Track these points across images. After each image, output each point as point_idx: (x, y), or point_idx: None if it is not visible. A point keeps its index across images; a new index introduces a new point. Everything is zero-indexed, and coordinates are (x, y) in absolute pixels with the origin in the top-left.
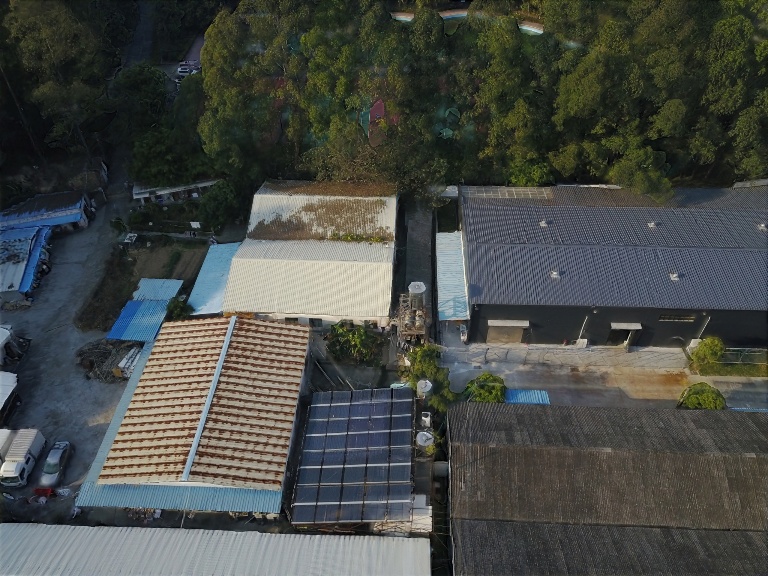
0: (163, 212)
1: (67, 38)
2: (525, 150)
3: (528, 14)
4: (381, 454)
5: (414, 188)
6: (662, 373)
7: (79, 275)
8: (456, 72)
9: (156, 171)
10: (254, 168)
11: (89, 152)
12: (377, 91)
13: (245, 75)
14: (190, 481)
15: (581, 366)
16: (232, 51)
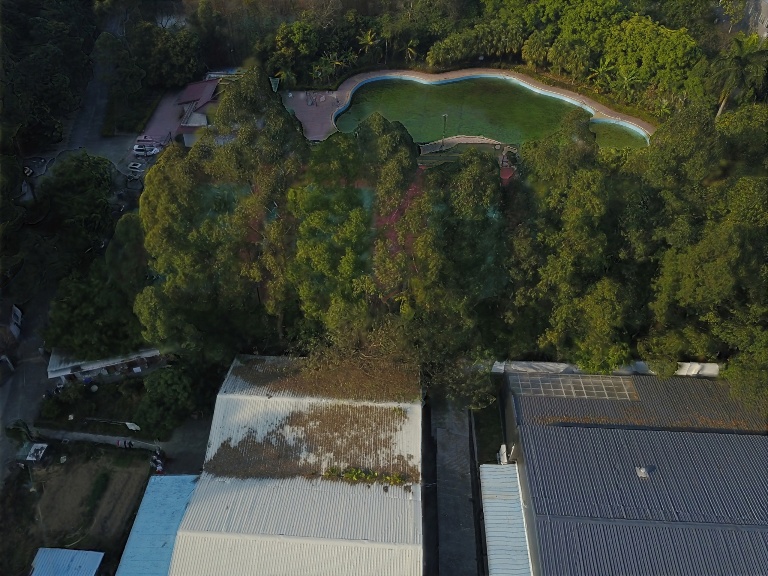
0: (90, 398)
1: None
2: (606, 342)
3: (558, 78)
4: None
5: None
6: None
7: None
8: (513, 236)
9: (80, 342)
10: (218, 350)
11: None
12: (401, 273)
13: (205, 237)
14: None
15: None
16: (185, 206)
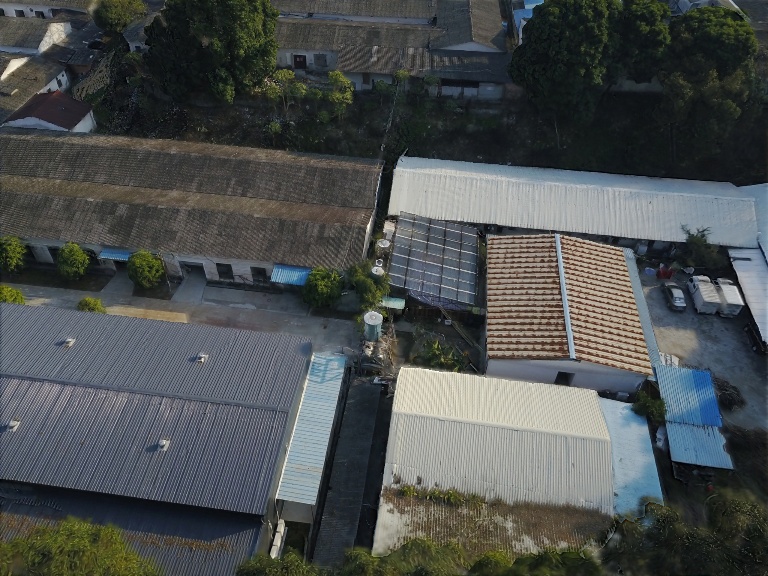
0: None
1: None
2: None
3: None
4: (417, 246)
5: None
6: None
7: None
8: None
9: None
10: None
11: None
12: None
13: None
14: None
15: None
16: None
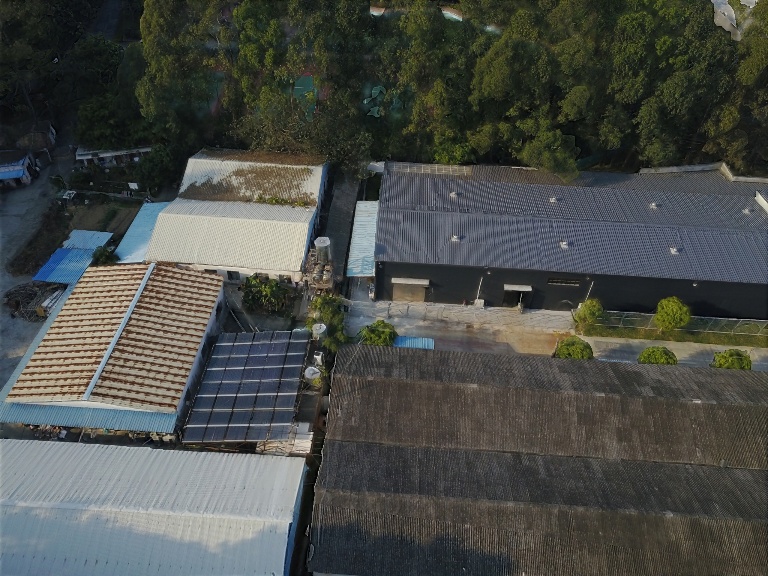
0: (104, 173)
1: (13, 0)
2: (444, 128)
3: None
4: (272, 385)
5: (342, 160)
6: (549, 332)
7: (16, 226)
8: (381, 51)
9: (99, 134)
10: (191, 134)
11: (35, 113)
12: (303, 64)
13: (181, 44)
14: (90, 401)
15: (476, 324)
16: (169, 20)
